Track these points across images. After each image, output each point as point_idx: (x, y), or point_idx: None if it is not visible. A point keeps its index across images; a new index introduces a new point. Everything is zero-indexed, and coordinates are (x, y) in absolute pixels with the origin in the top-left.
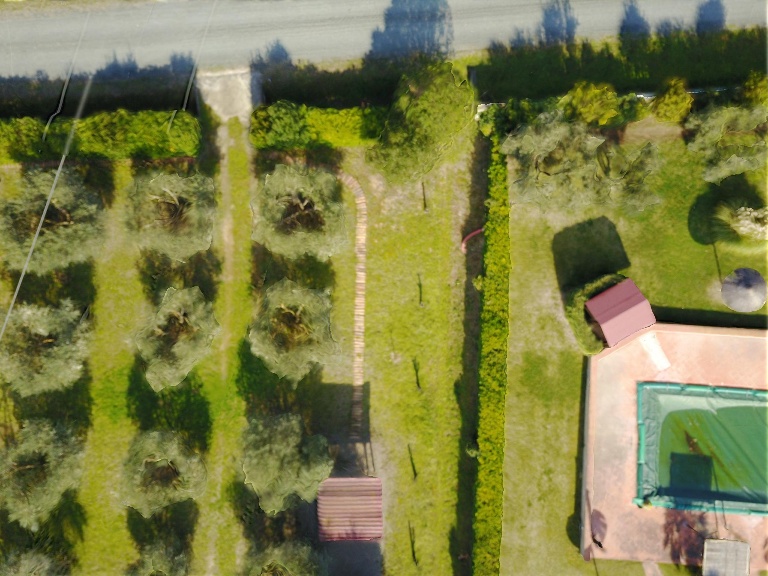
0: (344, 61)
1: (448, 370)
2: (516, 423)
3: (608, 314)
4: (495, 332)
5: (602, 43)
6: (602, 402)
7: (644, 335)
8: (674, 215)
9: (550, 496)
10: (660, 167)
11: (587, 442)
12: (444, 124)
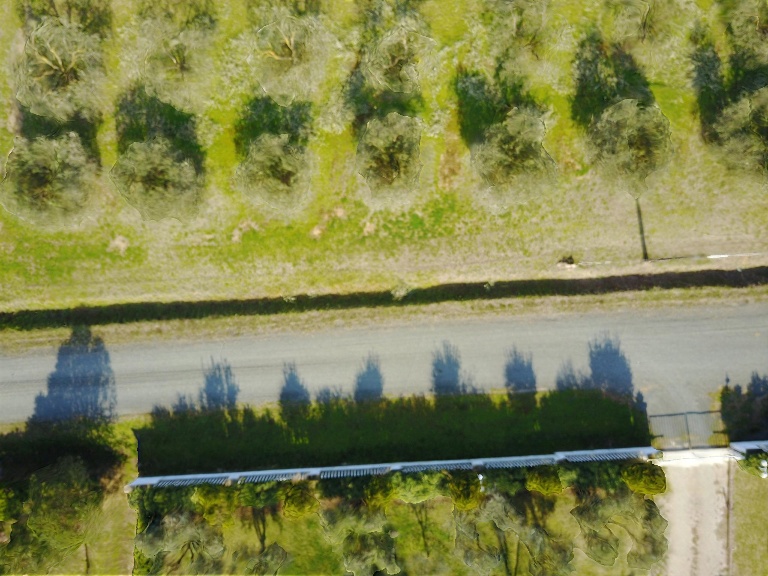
0: (7, 424)
1: None
2: None
3: None
4: None
5: (262, 409)
6: None
7: None
8: None
9: None
10: (313, 537)
11: None
12: (58, 540)
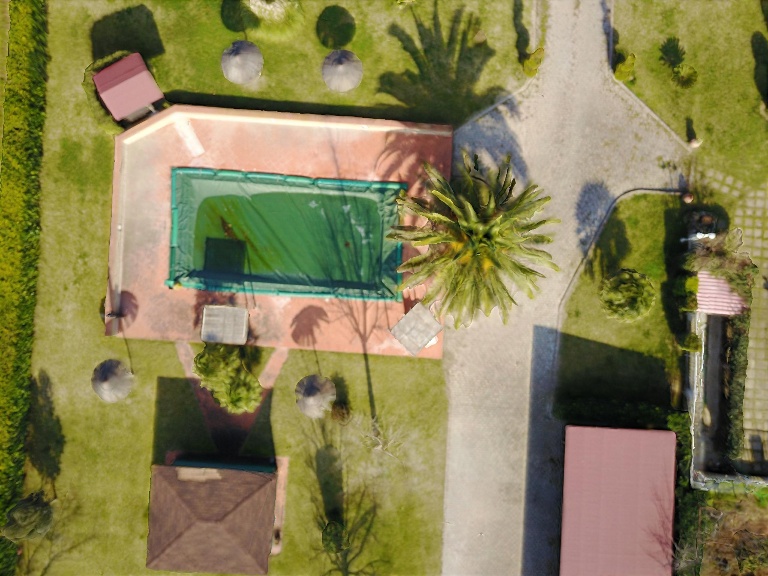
0: None
1: (0, 163)
2: (54, 209)
3: (108, 85)
4: (14, 110)
5: None
6: (137, 187)
7: (178, 121)
8: (209, 3)
9: (85, 280)
10: None
11: (111, 222)
12: None
